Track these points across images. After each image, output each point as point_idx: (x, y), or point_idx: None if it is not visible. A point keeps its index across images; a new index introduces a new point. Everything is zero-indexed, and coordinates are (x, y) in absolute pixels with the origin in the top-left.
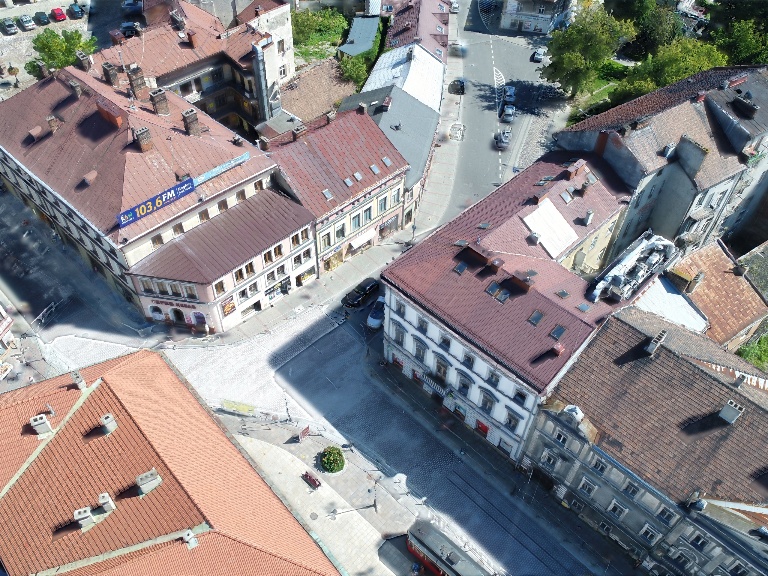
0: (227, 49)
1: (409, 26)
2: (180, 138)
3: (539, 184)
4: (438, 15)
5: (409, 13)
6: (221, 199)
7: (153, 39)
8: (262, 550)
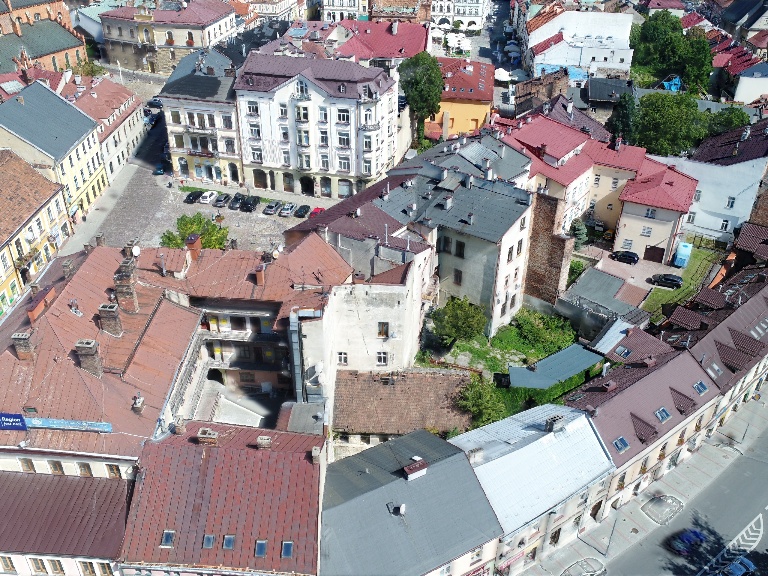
0: (288, 302)
1: (607, 387)
2: (68, 365)
3: None
4: (677, 394)
5: (636, 371)
6: (54, 458)
7: (233, 258)
8: None
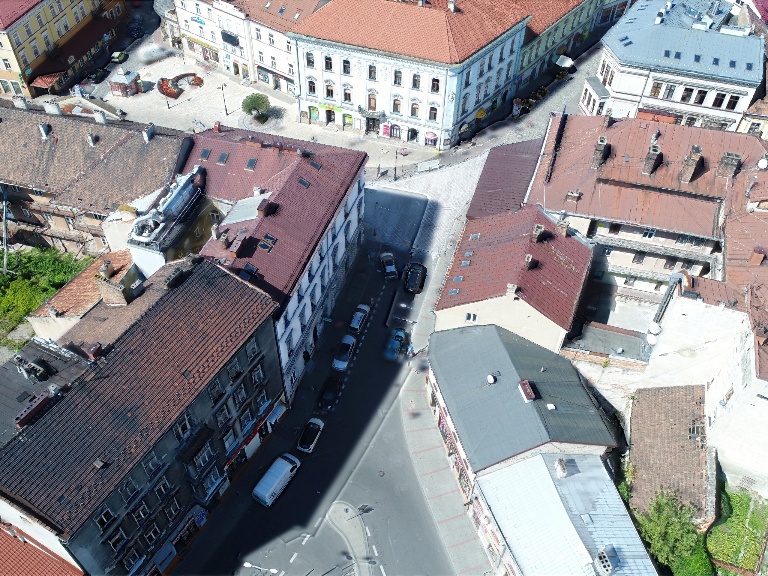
0: (725, 285)
1: None
2: None
3: (273, 237)
4: None
5: None
6: None
7: None
8: (324, 6)
